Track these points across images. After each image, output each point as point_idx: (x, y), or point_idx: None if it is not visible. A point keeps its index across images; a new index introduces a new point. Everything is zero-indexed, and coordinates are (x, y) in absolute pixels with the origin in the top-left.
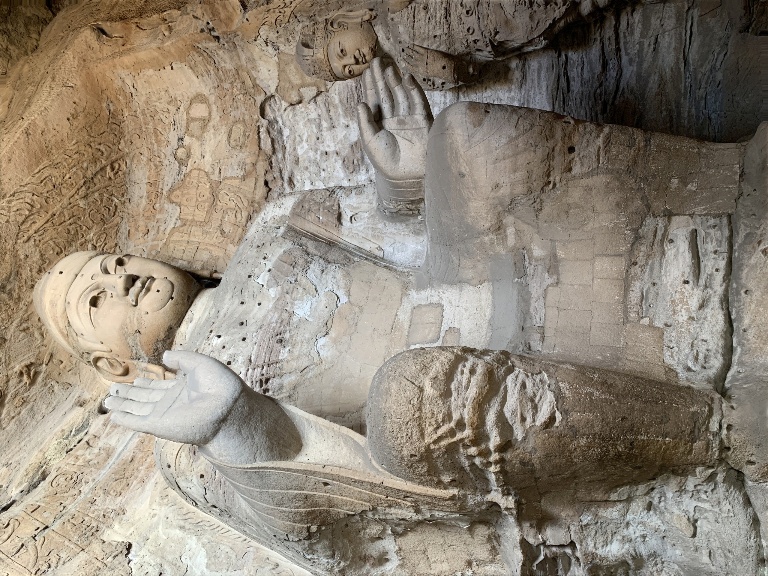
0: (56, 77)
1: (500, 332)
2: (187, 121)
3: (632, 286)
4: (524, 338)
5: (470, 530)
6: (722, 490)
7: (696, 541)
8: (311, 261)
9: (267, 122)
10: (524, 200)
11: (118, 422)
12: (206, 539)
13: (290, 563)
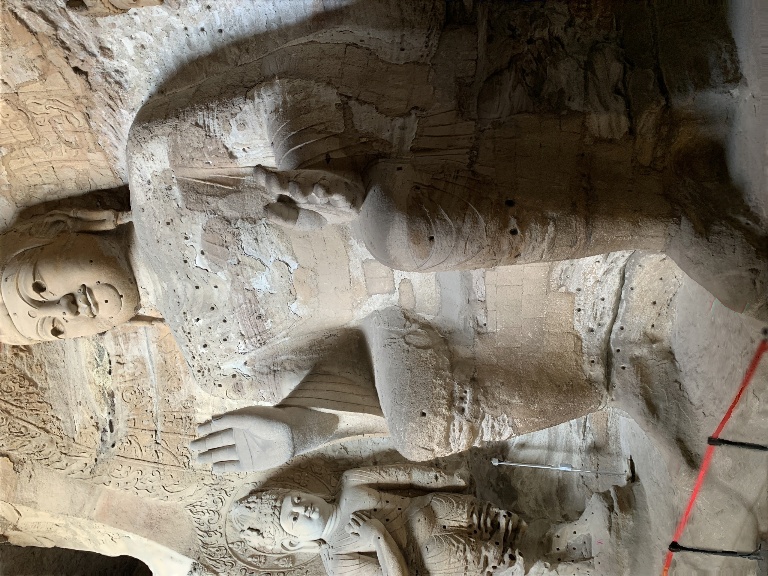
0: None
1: (448, 293)
2: None
3: (555, 268)
4: (472, 313)
5: None
6: None
7: None
8: (238, 232)
9: None
10: None
11: None
12: None
13: None
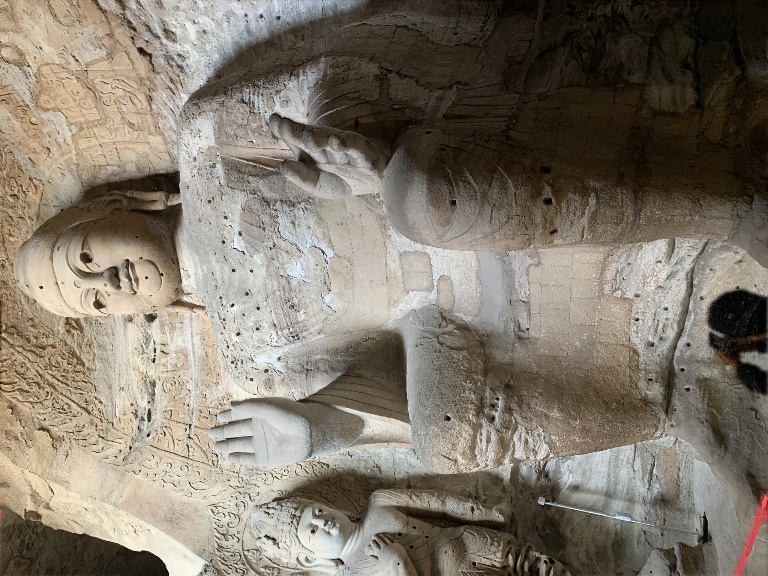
0: None
1: (489, 293)
2: None
3: (609, 267)
4: (513, 315)
5: None
6: None
7: None
8: (276, 214)
9: None
10: None
11: None
12: None
13: None
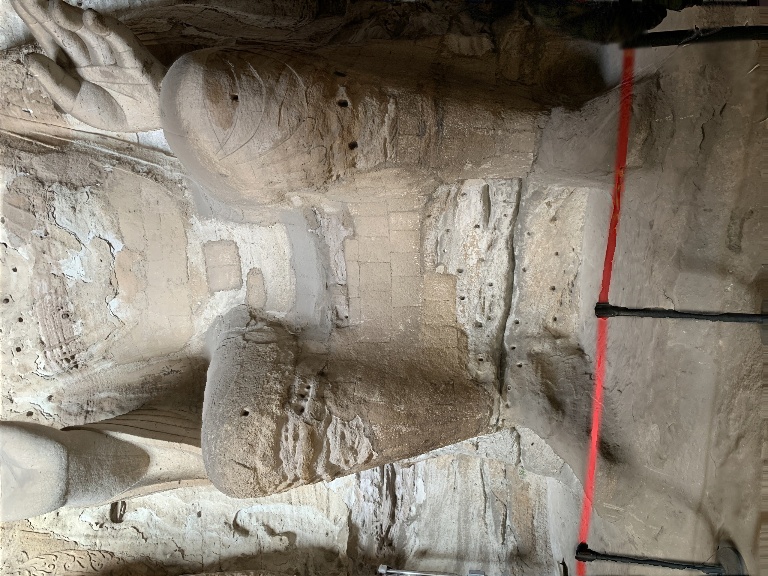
0: None
1: (304, 282)
2: None
3: (427, 234)
4: (330, 301)
5: None
6: None
7: (478, 451)
8: (52, 196)
9: None
10: (306, 188)
11: None
12: None
13: None
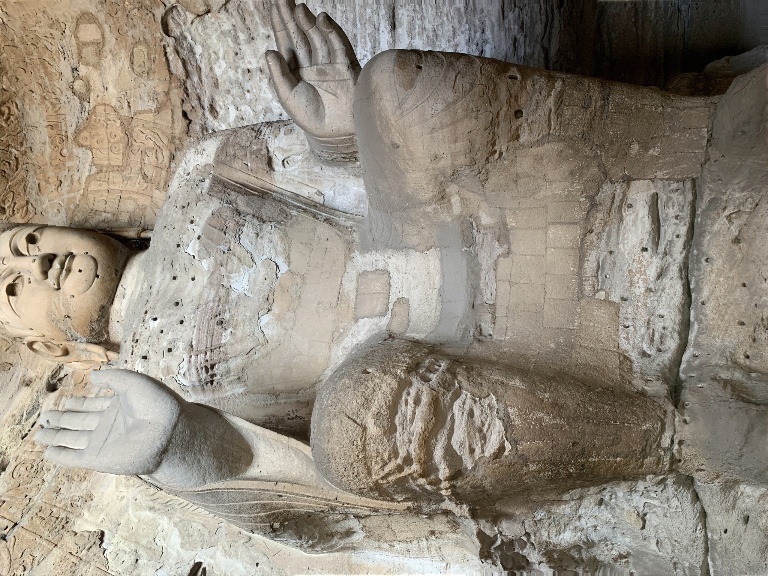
0: None
1: (450, 306)
2: (78, 46)
3: (587, 255)
4: (475, 319)
5: (429, 518)
6: (671, 490)
7: (645, 532)
8: (243, 223)
9: (173, 40)
10: (468, 171)
11: (54, 460)
12: (177, 518)
13: None
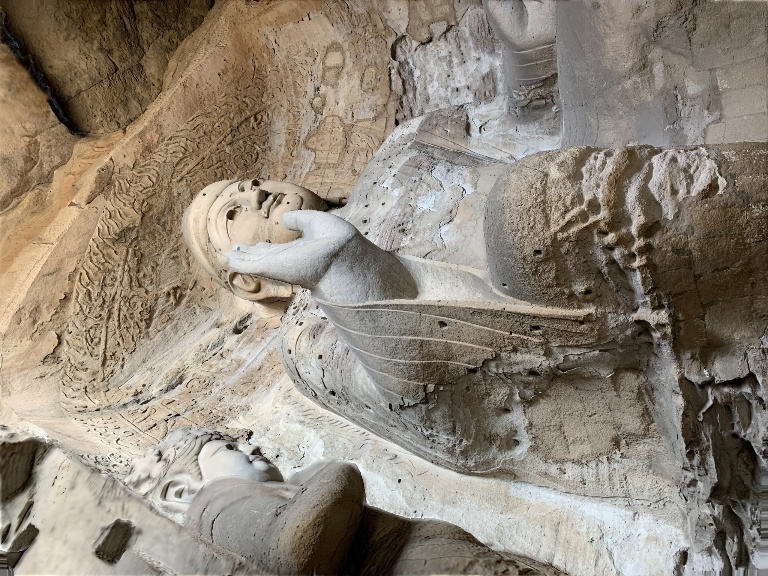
0: (211, 40)
1: None
2: (323, 71)
3: None
4: None
5: (614, 382)
6: None
7: None
8: (437, 163)
9: (398, 63)
10: (673, 20)
11: (236, 266)
12: (324, 432)
13: (409, 454)
